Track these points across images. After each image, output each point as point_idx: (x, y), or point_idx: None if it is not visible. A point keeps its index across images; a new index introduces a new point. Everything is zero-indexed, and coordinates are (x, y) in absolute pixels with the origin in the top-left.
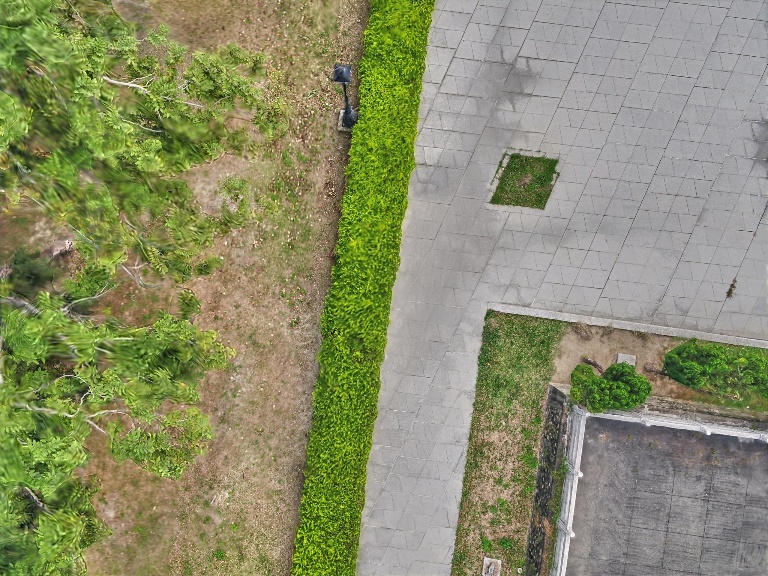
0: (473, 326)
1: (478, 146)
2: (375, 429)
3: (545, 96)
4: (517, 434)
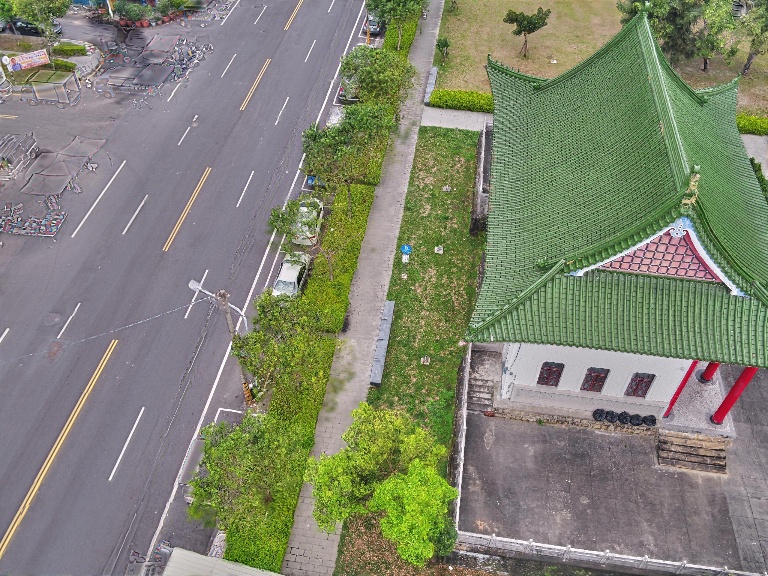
0: None
1: None
2: None
3: None
4: None
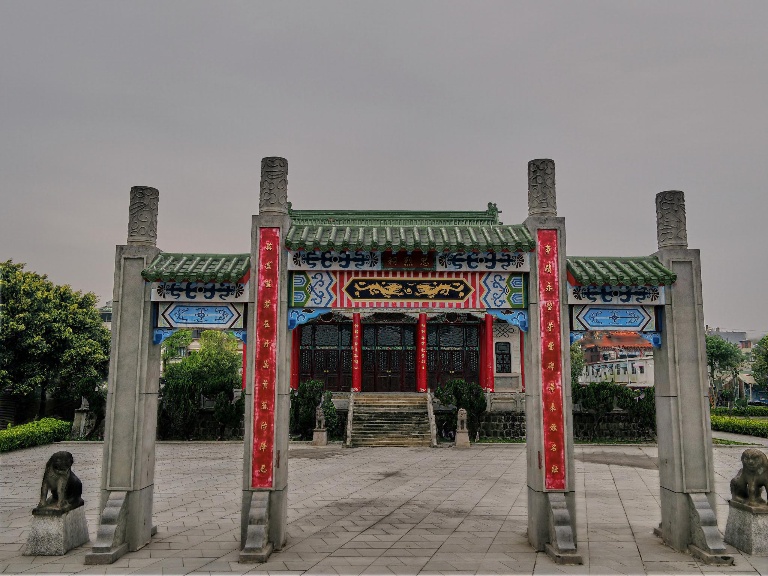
0: None
1: None
2: None
3: None
4: None
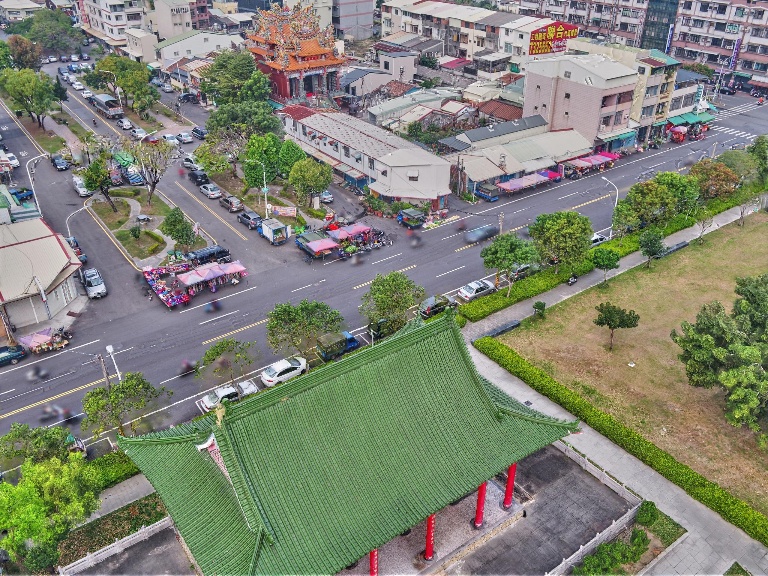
0: None
1: (766, 575)
2: None
3: None
4: None
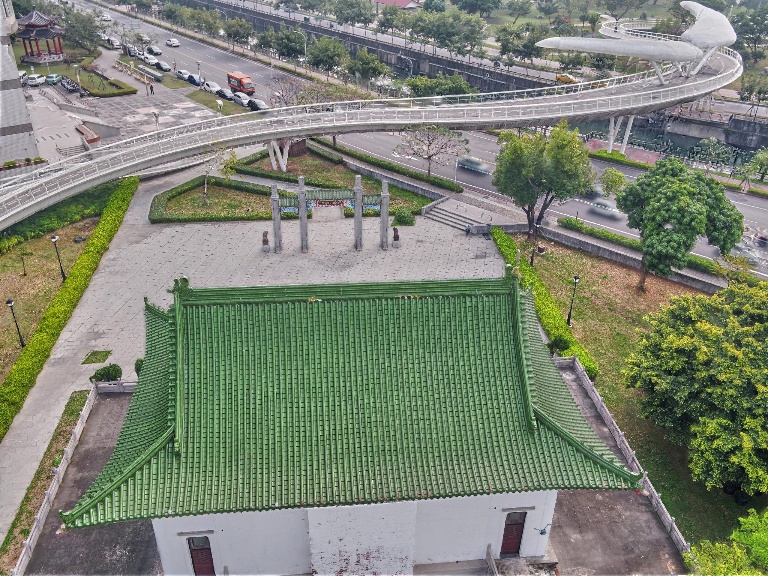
0: (65, 397)
1: None
2: (8, 435)
3: (109, 337)
4: None
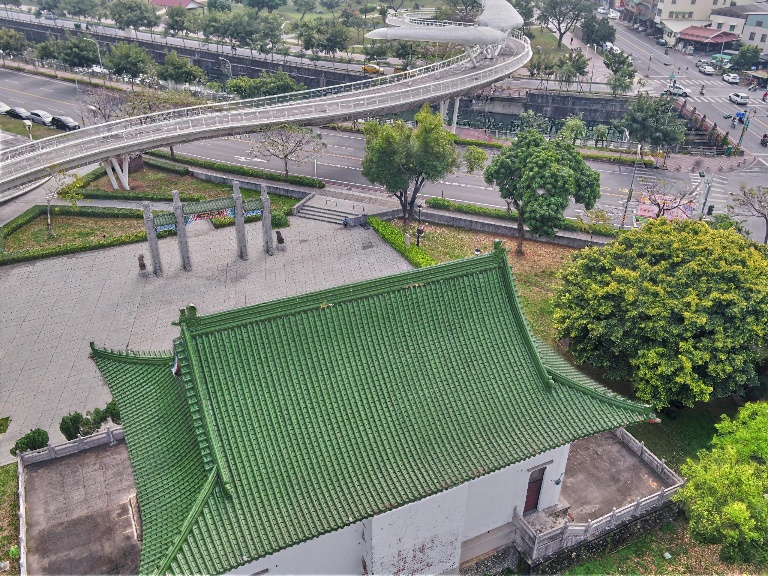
0: None
1: None
2: None
3: None
4: (8, 508)
